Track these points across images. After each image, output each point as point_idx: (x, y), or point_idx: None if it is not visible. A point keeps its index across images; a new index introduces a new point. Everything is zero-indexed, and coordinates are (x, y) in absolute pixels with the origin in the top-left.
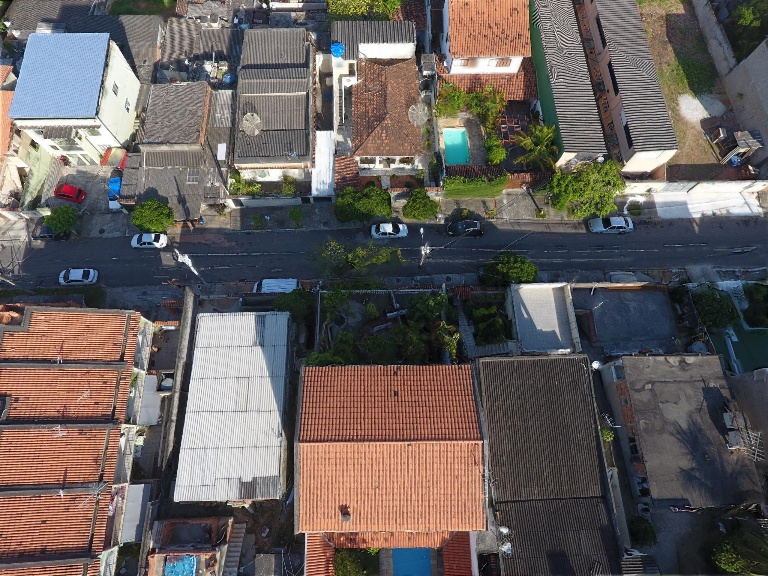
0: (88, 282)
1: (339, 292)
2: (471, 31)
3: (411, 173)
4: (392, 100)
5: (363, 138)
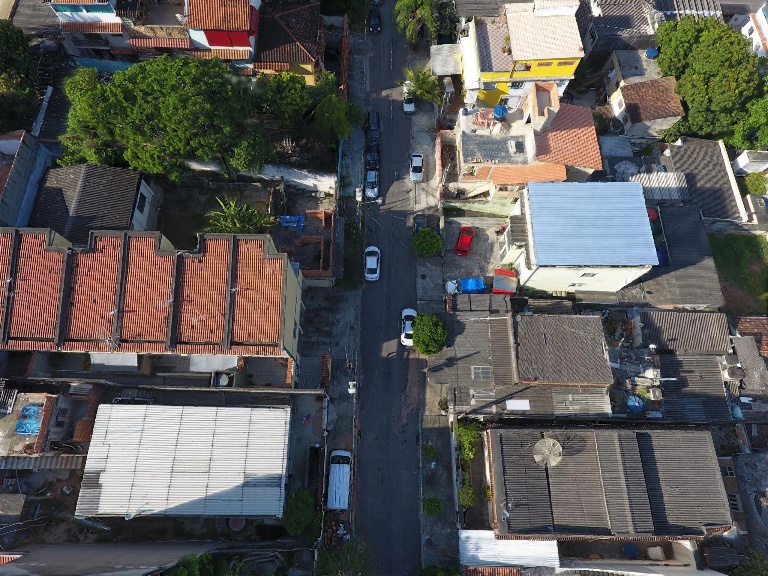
0: (365, 274)
1: None
2: None
3: None
4: None
5: None
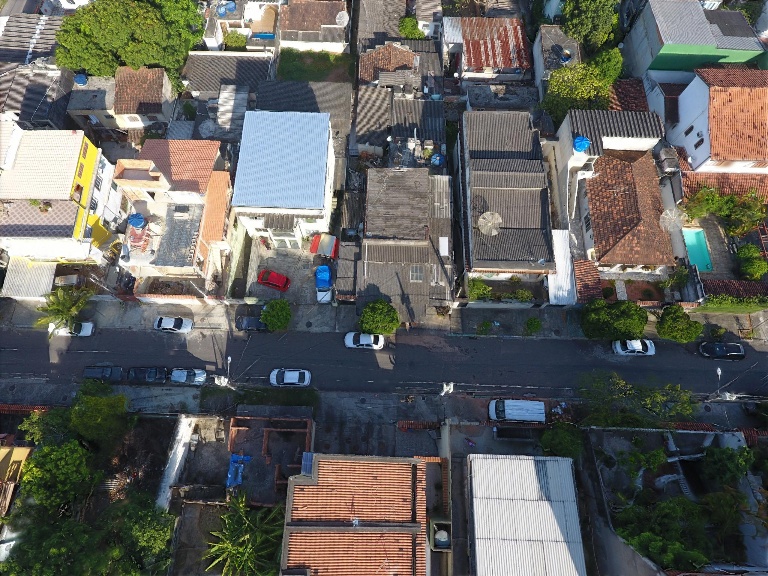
0: (303, 385)
1: (658, 454)
2: (734, 130)
3: (647, 278)
4: (641, 202)
5: (610, 243)
